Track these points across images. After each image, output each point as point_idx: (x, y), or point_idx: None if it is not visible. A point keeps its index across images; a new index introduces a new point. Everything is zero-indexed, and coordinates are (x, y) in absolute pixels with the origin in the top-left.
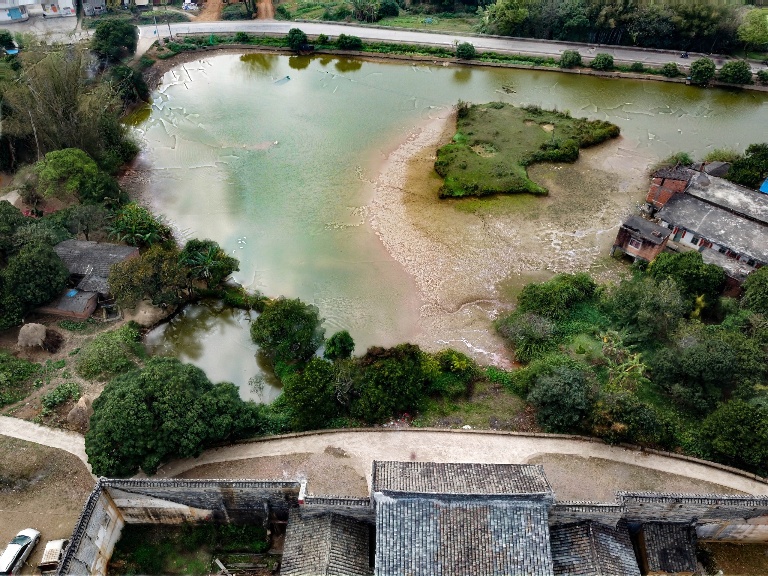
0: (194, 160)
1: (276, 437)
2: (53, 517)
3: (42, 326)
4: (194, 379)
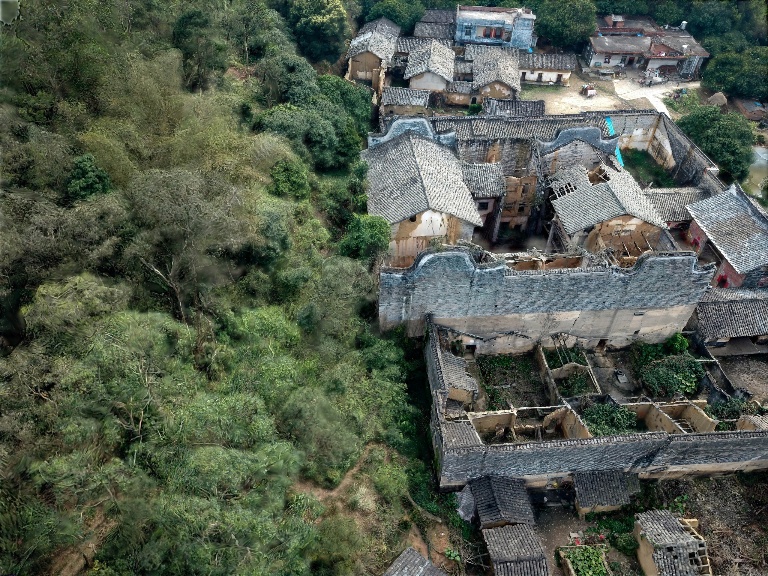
0: None
1: None
2: None
3: (726, 100)
4: (744, 135)
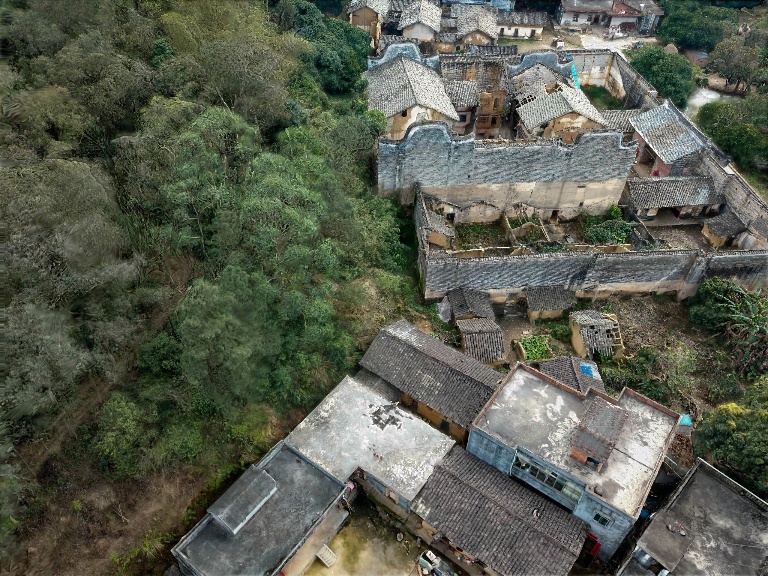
0: None
1: None
2: None
3: (677, 51)
4: (684, 70)
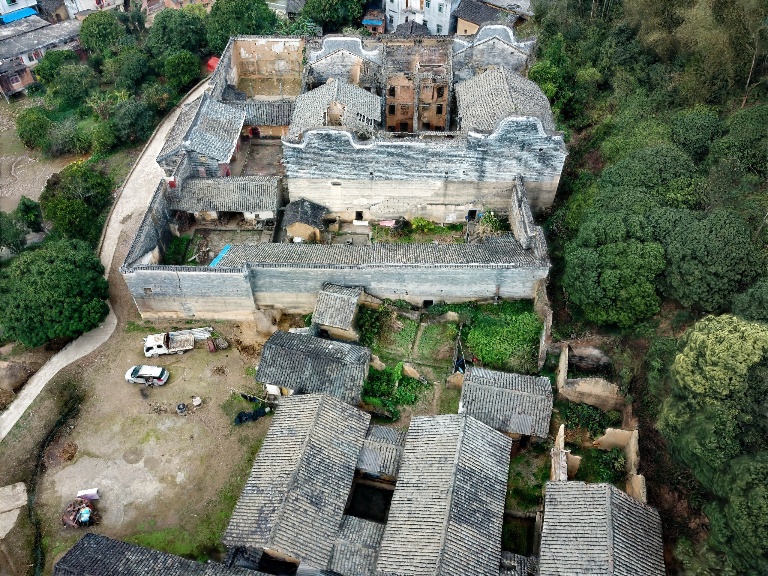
0: None
1: (100, 246)
2: (119, 368)
3: None
4: None
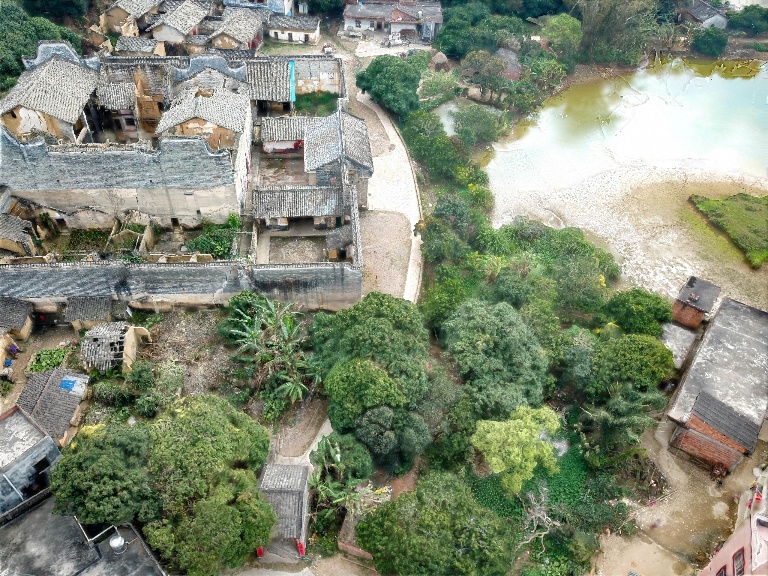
0: (645, 89)
1: (396, 128)
2: None
3: (446, 59)
4: (407, 78)
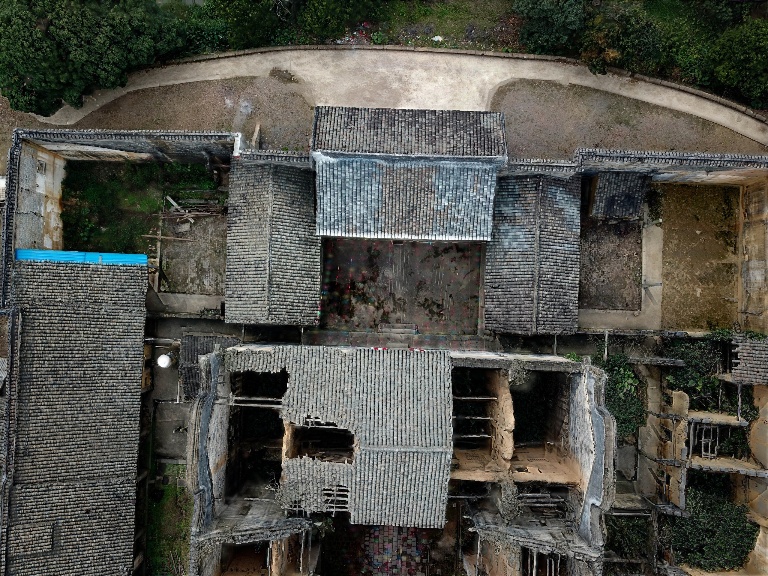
0: None
1: (212, 57)
2: None
3: None
4: None
